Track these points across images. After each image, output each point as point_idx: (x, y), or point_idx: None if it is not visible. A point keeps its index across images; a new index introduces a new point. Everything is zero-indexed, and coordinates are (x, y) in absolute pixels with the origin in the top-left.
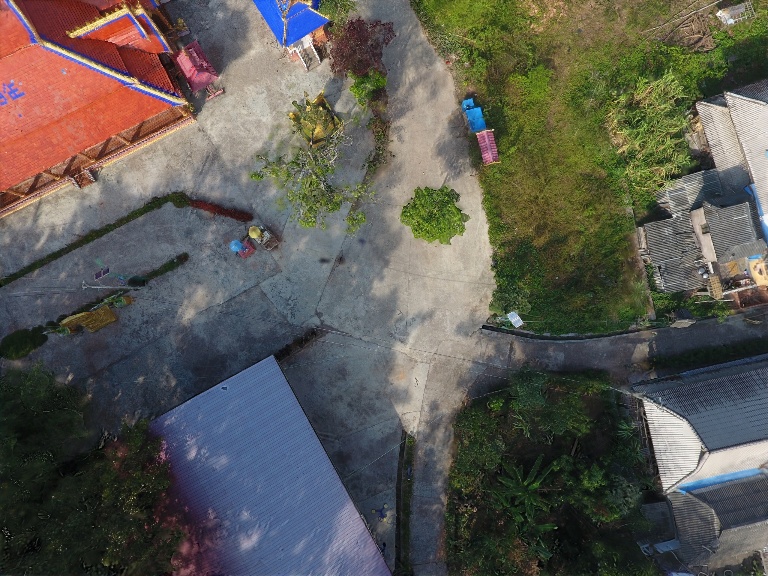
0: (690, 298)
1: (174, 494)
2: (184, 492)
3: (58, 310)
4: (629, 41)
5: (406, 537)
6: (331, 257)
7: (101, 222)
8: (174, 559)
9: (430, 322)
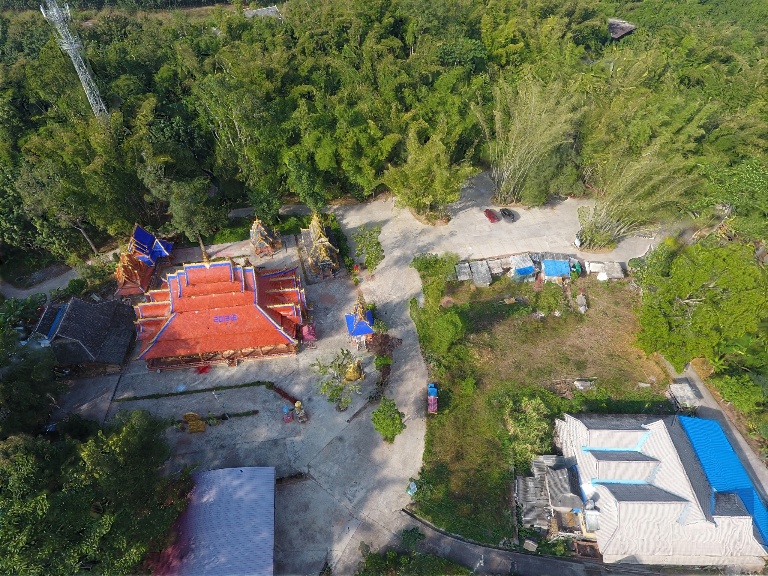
0: (545, 539)
1: (180, 522)
2: (186, 521)
3: (180, 417)
4: (526, 383)
5: None
6: (330, 437)
7: (228, 384)
8: (150, 569)
9: (371, 494)
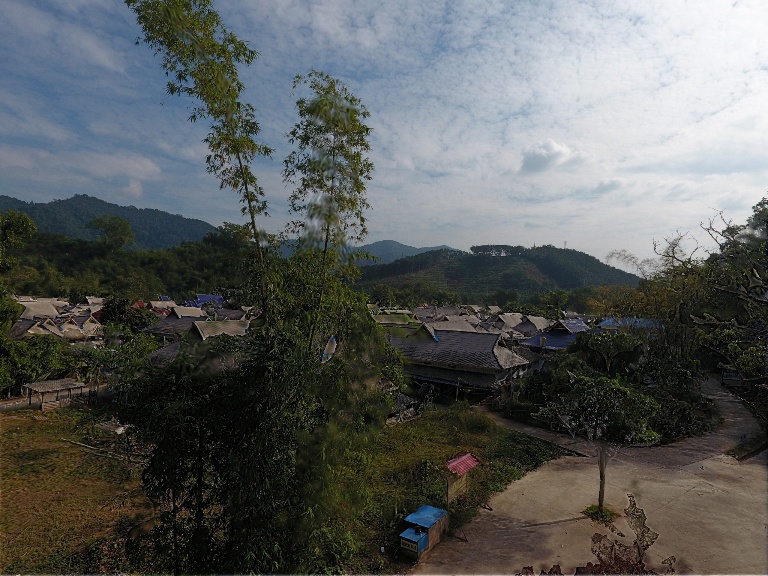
0: None
1: None
2: None
3: None
4: None
5: (763, 436)
6: None
7: None
8: None
9: (657, 478)
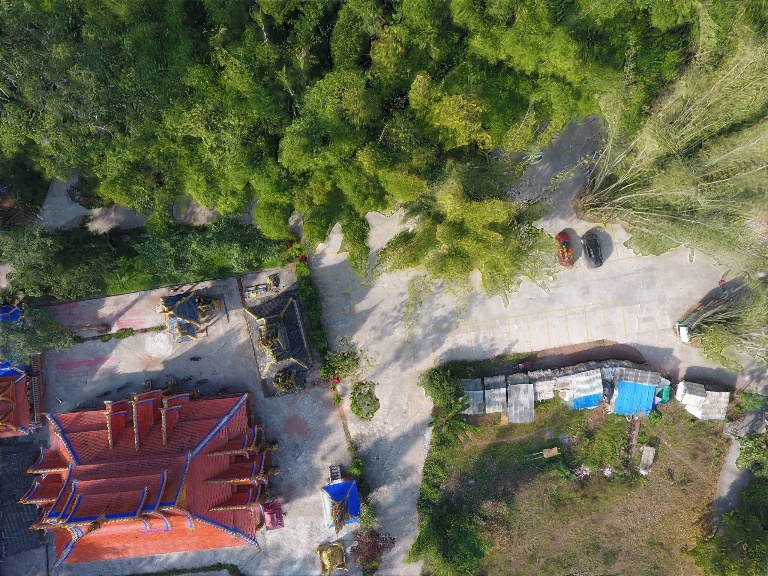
0: None
1: None
2: None
3: None
4: None
5: None
6: None
7: (182, 565)
8: None
9: None
